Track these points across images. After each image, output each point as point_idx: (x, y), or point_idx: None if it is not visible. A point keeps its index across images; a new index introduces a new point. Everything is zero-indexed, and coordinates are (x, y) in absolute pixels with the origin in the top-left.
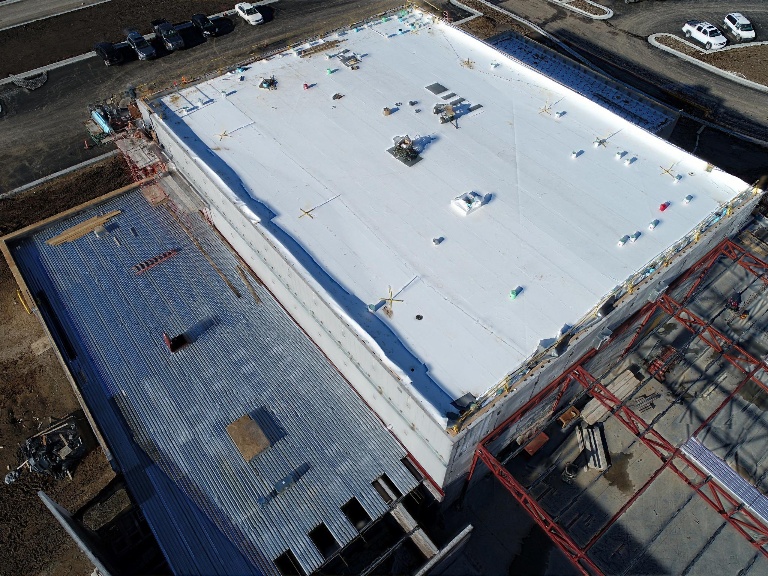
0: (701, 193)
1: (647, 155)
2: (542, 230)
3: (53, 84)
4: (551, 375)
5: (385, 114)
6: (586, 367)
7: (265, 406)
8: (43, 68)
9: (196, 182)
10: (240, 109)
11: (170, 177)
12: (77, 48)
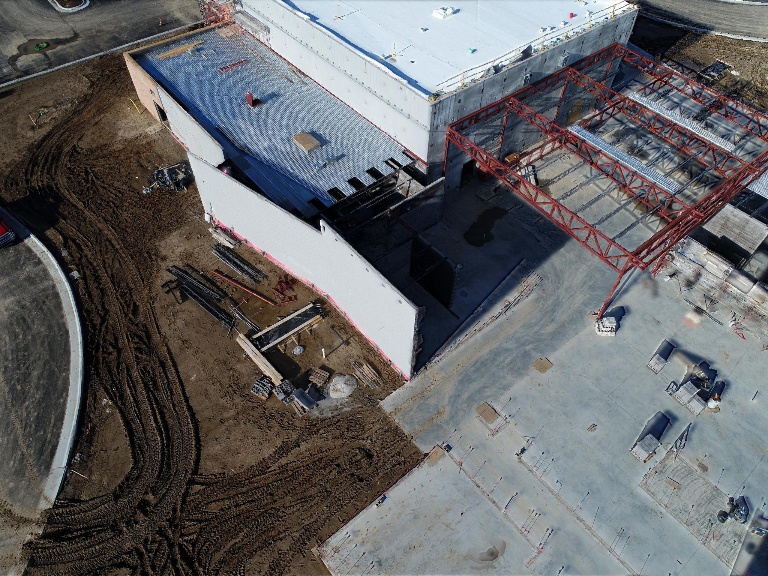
0: None
1: None
2: (492, 25)
3: None
4: (493, 93)
5: None
6: None
7: (315, 131)
8: None
9: (260, 12)
10: None
11: (240, 14)
12: None
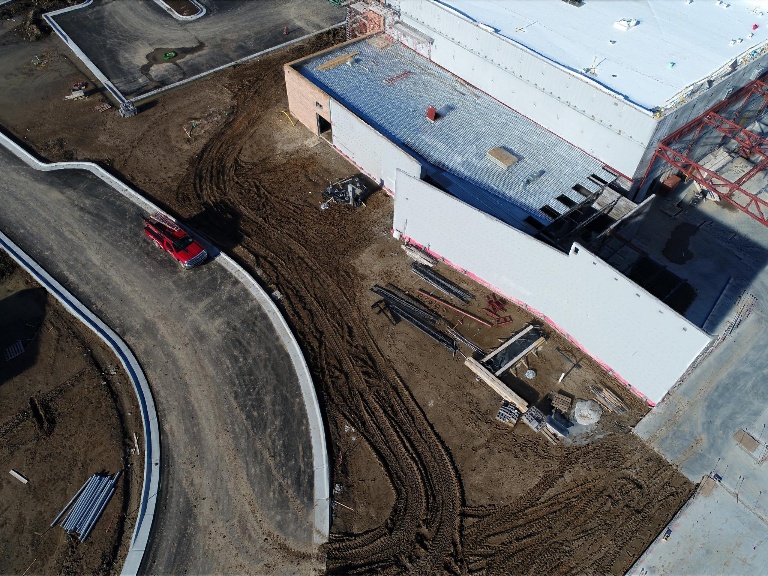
0: None
1: (737, 3)
2: (679, 37)
3: None
4: (699, 108)
5: None
6: (707, 128)
7: (505, 146)
8: None
9: (425, 23)
10: None
11: (399, 24)
12: None
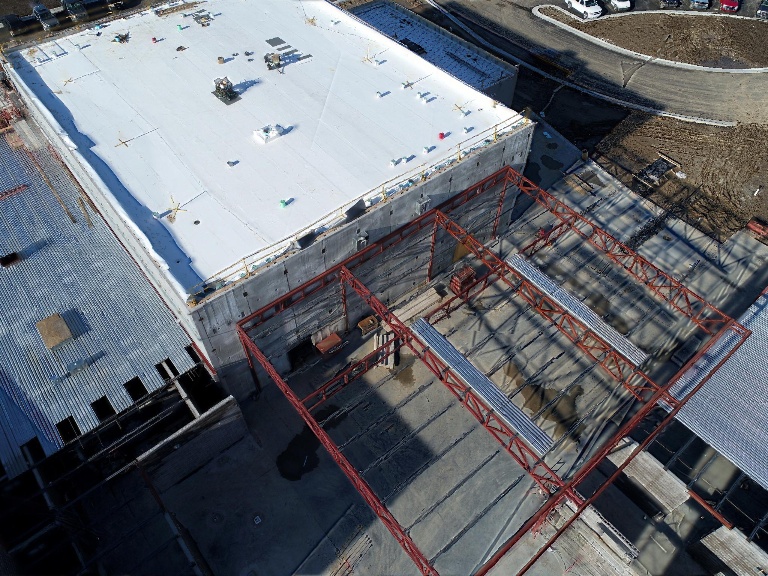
0: (483, 125)
1: (446, 95)
2: (328, 154)
3: None
4: (307, 269)
5: (219, 62)
6: (369, 275)
7: (77, 308)
8: None
9: (42, 123)
10: (90, 60)
11: (24, 121)
12: None
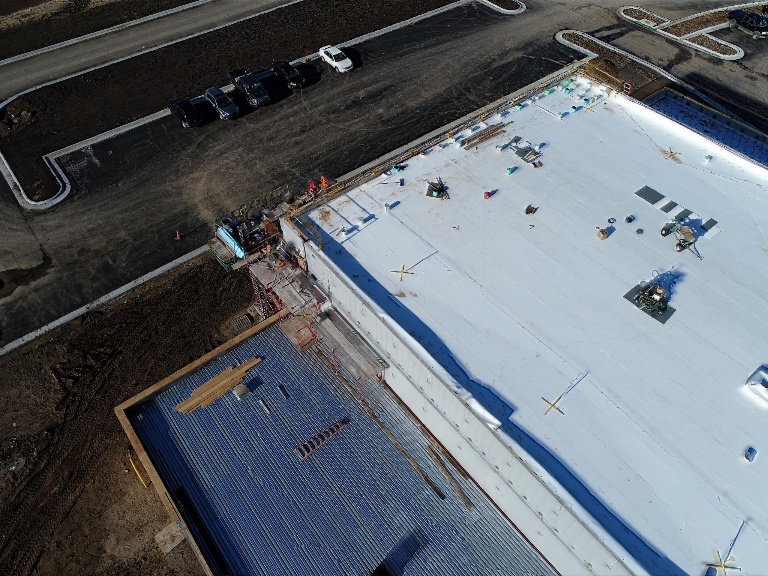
0: None
1: None
2: None
3: (126, 152)
4: None
5: (602, 238)
6: None
7: None
8: (112, 131)
9: (372, 336)
10: (412, 230)
11: (329, 321)
12: (147, 105)
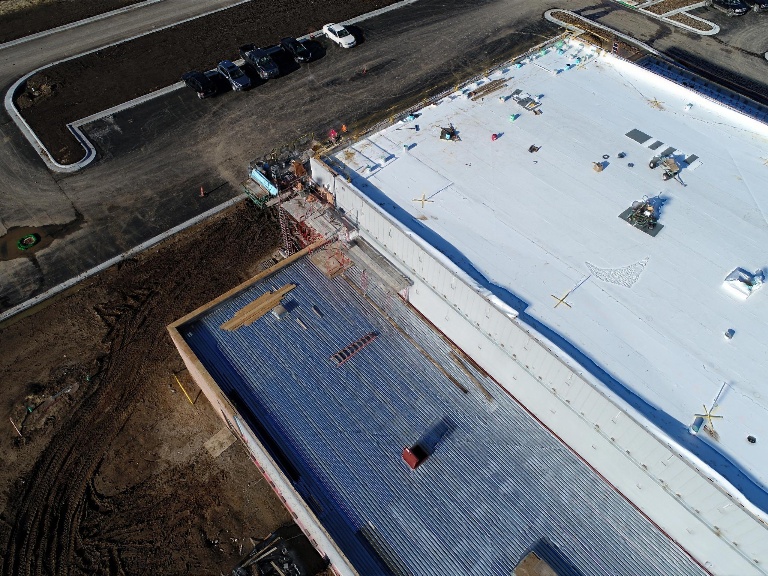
0: None
1: None
2: None
3: (146, 121)
4: None
5: (598, 170)
6: None
7: (544, 537)
8: (131, 102)
9: (398, 256)
10: (430, 166)
11: (358, 247)
12: (163, 78)
